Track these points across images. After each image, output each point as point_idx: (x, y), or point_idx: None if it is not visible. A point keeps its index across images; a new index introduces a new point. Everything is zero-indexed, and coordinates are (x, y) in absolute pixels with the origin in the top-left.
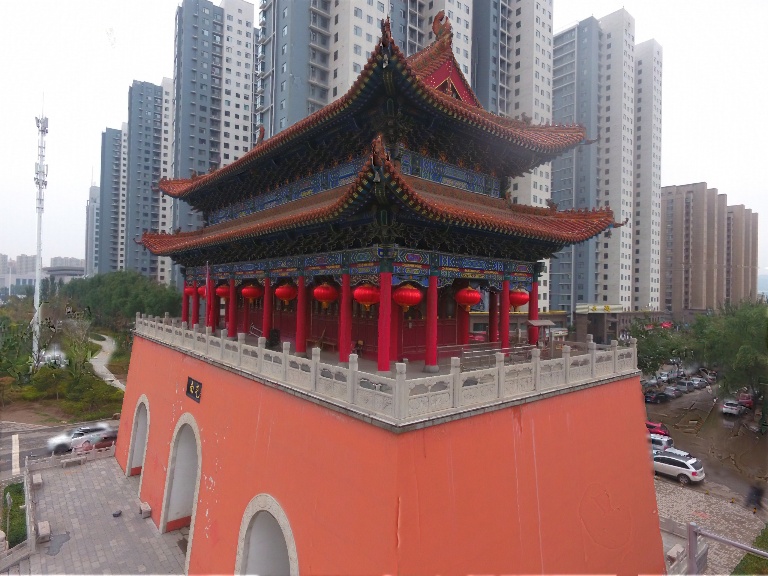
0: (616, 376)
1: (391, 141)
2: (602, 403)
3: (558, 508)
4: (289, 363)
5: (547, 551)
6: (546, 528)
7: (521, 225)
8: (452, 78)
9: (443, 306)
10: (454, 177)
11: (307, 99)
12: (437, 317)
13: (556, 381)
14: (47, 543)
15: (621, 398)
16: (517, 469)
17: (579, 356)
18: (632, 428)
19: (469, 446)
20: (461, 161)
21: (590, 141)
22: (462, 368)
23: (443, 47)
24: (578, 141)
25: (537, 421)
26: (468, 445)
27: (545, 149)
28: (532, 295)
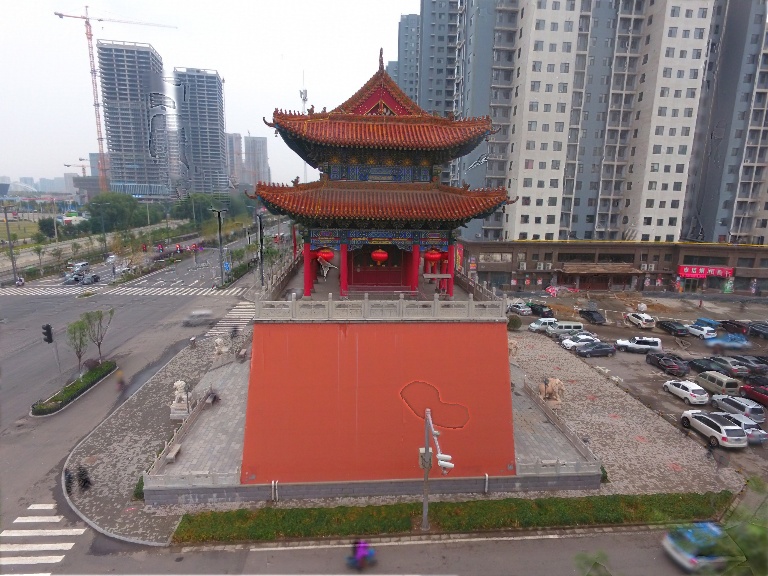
0: (465, 319)
1: (322, 161)
2: (442, 335)
3: (376, 385)
4: (274, 286)
5: (363, 404)
6: (363, 392)
7: (392, 212)
8: (384, 100)
9: (389, 258)
10: (379, 174)
11: (494, 28)
12: (384, 265)
13: (389, 315)
14: (242, 358)
15: (471, 335)
16: (340, 356)
17: (418, 302)
18: (486, 358)
19: (301, 337)
20: (389, 160)
21: (492, 132)
22: (343, 300)
23: (379, 77)
24: (480, 134)
25: (362, 334)
26: (300, 336)
27: (441, 147)
28: (448, 254)
